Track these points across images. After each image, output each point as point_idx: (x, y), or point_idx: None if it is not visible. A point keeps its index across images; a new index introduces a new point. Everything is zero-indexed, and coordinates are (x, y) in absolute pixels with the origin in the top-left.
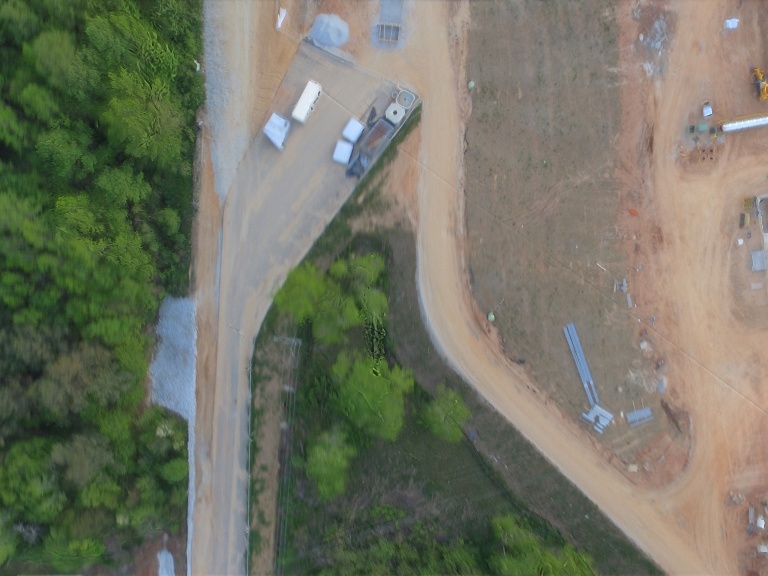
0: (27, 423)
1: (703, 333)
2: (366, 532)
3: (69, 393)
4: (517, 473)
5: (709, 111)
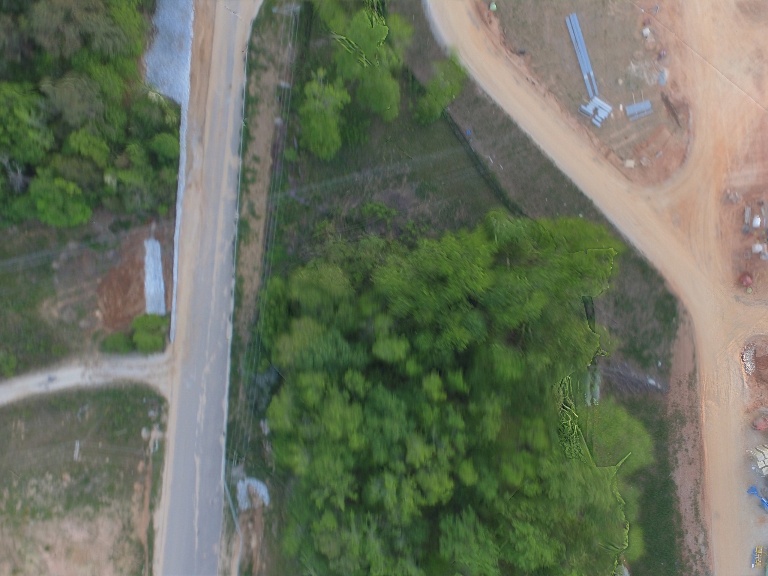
0: (17, 66)
1: (707, 26)
2: (357, 232)
3: (61, 30)
4: (512, 173)
5: None
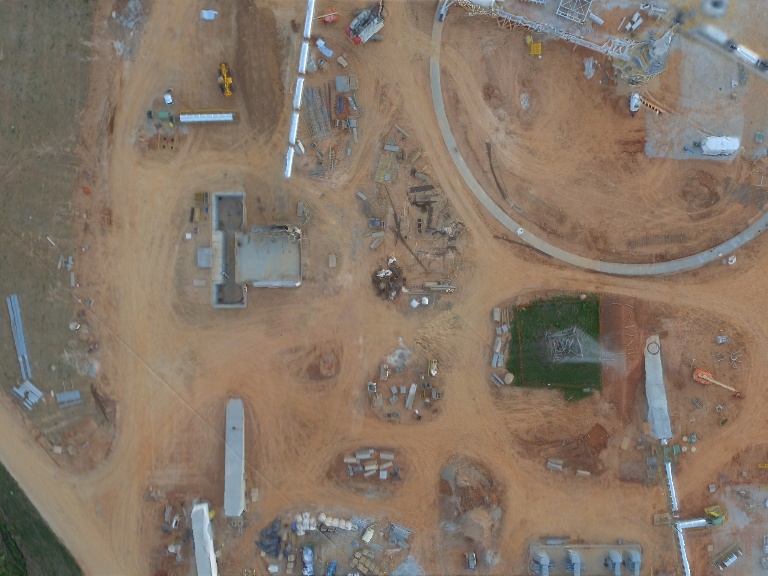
0: None
1: (142, 323)
2: None
3: None
4: None
5: (169, 99)
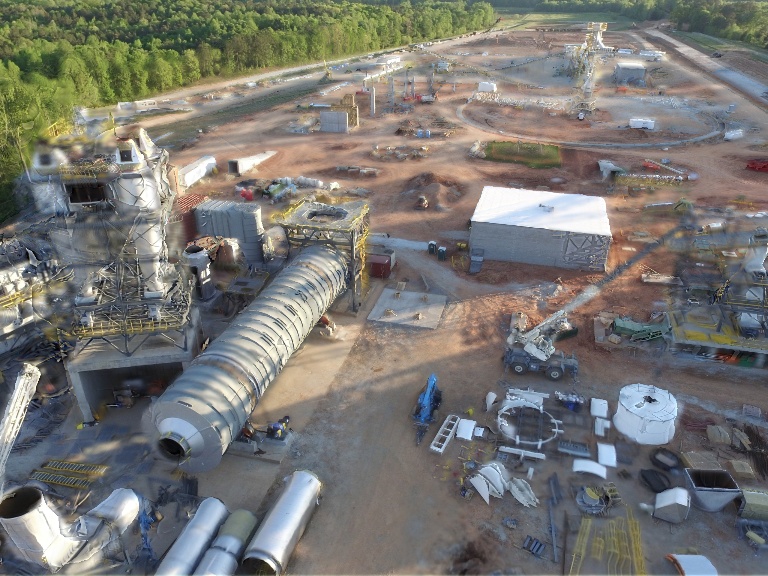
0: None
1: None
2: None
3: None
4: None
5: None
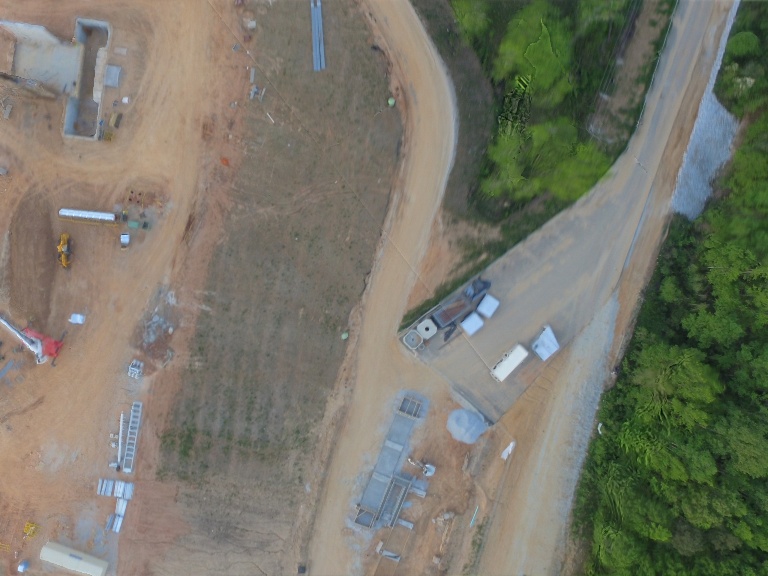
0: None
1: (188, 20)
2: None
3: None
4: None
5: (124, 239)
